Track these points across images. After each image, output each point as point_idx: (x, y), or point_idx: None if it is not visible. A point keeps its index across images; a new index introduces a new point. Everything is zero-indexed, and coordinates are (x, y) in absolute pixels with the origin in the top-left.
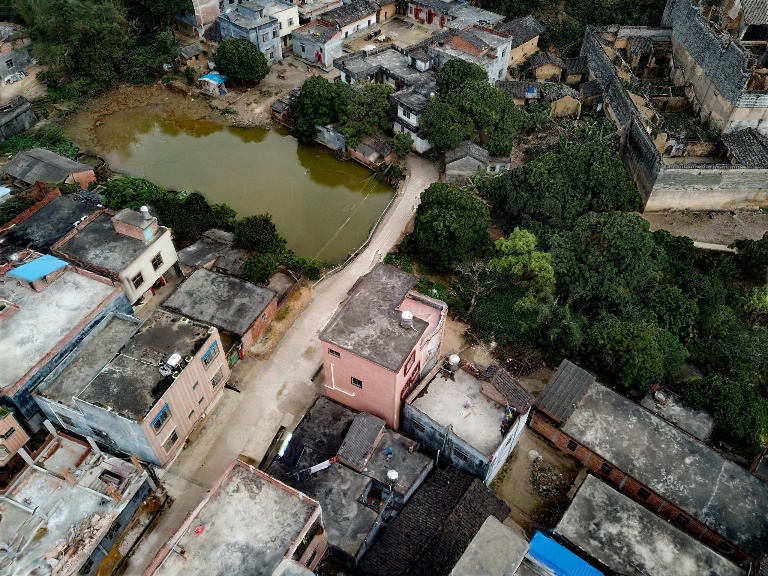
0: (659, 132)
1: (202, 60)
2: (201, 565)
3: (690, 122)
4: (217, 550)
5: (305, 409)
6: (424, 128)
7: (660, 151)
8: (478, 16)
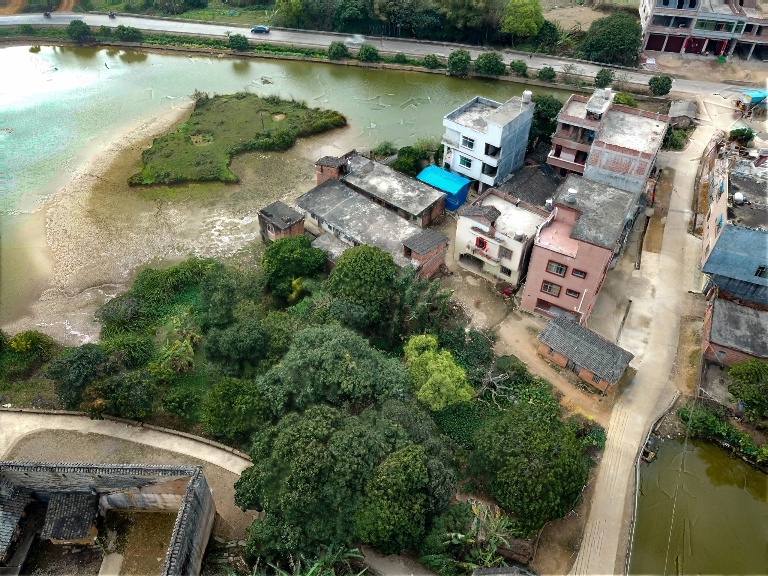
0: None
1: None
2: (643, 130)
3: None
4: (638, 134)
5: None
6: None
7: None
8: None
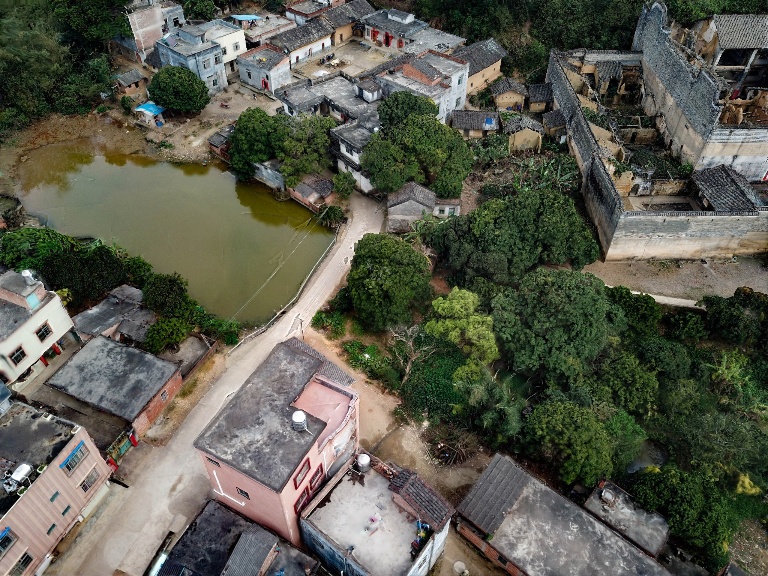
0: (623, 170)
1: (142, 87)
2: None
3: (661, 155)
4: None
5: (192, 517)
6: (365, 168)
7: (626, 190)
8: (437, 39)
